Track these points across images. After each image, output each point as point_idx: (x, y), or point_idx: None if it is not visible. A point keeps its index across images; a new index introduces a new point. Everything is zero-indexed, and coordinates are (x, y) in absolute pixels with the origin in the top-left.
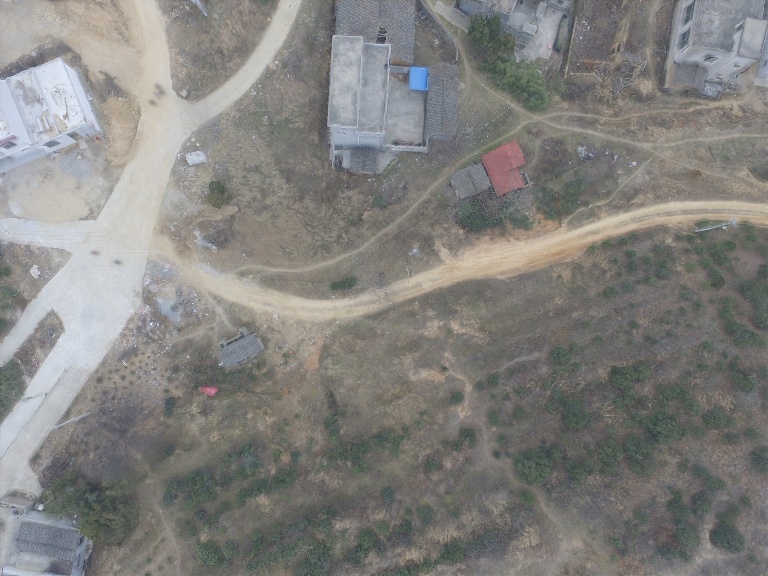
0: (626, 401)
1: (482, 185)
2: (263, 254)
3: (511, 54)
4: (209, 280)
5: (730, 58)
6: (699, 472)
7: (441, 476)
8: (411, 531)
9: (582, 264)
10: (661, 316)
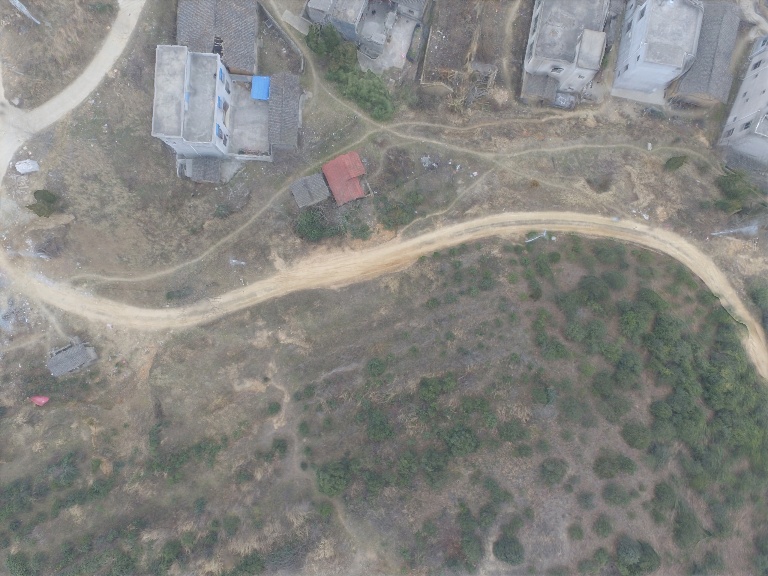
0: (428, 412)
1: (320, 195)
2: (99, 263)
3: (354, 64)
4: (42, 289)
5: (572, 69)
6: (488, 484)
7: (250, 487)
8: (214, 543)
9: (410, 274)
10: (477, 327)
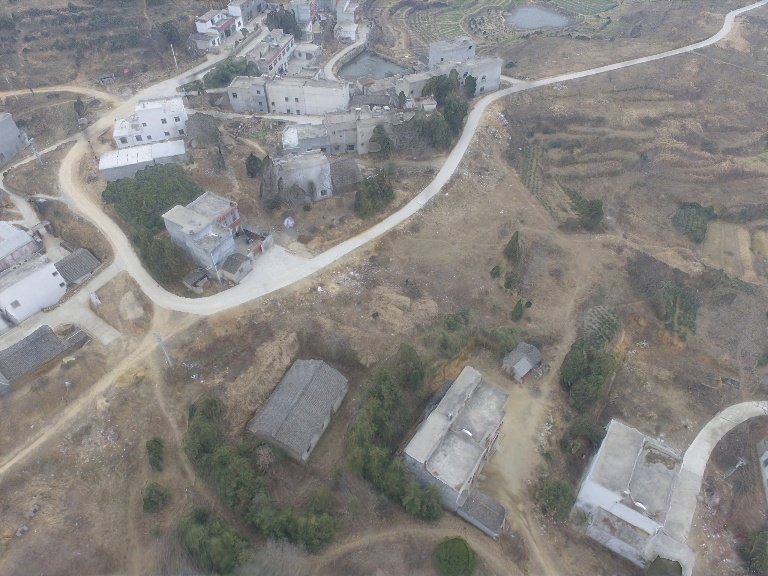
0: None
1: None
2: None
3: None
4: (107, 96)
5: None
6: None
7: (43, 31)
8: (61, 19)
9: None
10: None
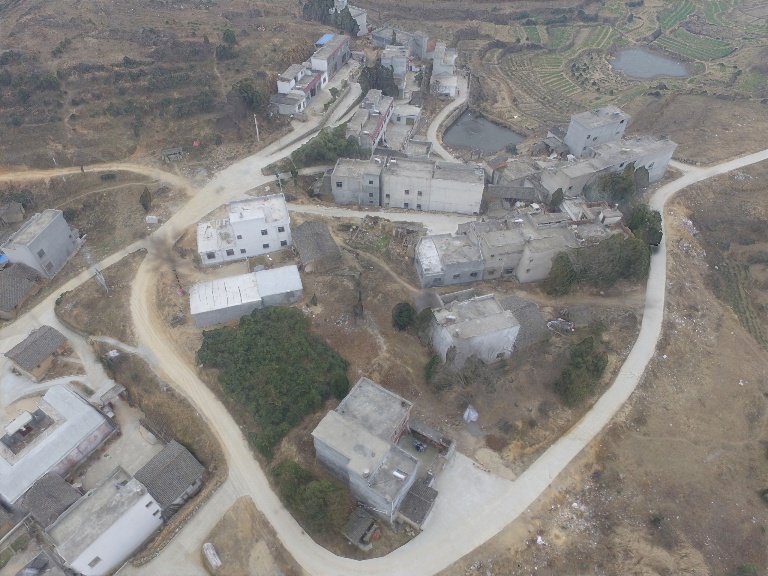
0: None
1: None
2: None
3: None
4: (176, 180)
5: None
6: None
7: (94, 92)
8: (115, 77)
9: None
10: None
